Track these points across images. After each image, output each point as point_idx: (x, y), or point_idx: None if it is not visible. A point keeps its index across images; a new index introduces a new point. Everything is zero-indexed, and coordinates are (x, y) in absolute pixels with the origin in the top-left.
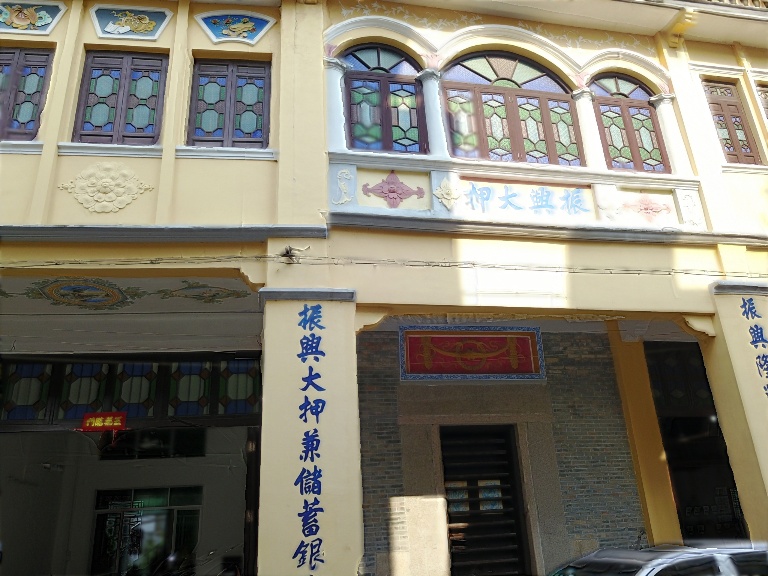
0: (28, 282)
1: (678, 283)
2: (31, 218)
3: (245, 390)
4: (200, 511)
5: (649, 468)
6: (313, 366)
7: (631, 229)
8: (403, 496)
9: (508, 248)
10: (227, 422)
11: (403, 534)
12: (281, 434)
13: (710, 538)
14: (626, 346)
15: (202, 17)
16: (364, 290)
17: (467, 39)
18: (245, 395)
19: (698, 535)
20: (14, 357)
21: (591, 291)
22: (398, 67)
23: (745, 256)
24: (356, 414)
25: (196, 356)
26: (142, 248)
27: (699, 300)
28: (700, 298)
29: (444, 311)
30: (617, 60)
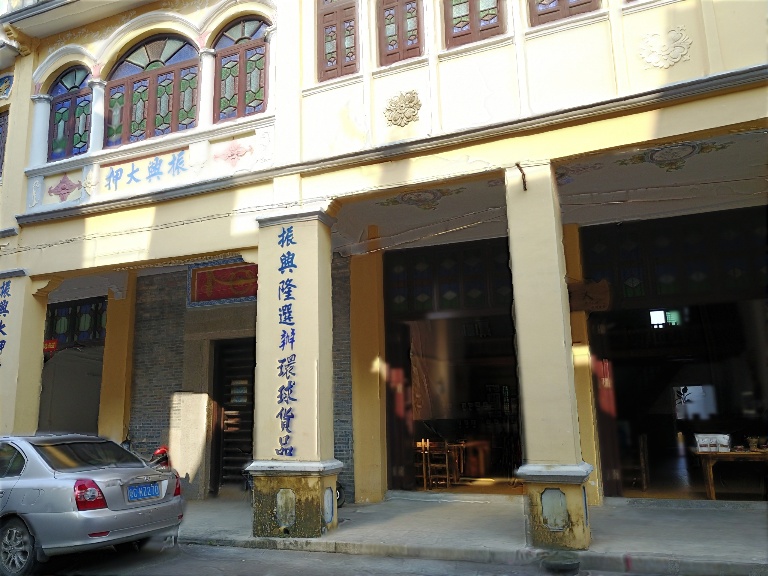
0: None
1: (235, 222)
2: None
3: None
4: None
5: (360, 370)
6: (3, 320)
7: (194, 183)
8: (181, 392)
9: (117, 218)
10: (98, 344)
11: (178, 418)
12: None
13: (480, 432)
14: (358, 259)
15: None
16: (35, 266)
17: (122, 38)
18: None
19: (471, 429)
20: None
21: (167, 242)
22: (85, 81)
23: (305, 182)
24: (19, 348)
25: (87, 301)
26: None
27: (249, 235)
28: (251, 233)
29: None
30: (237, 5)
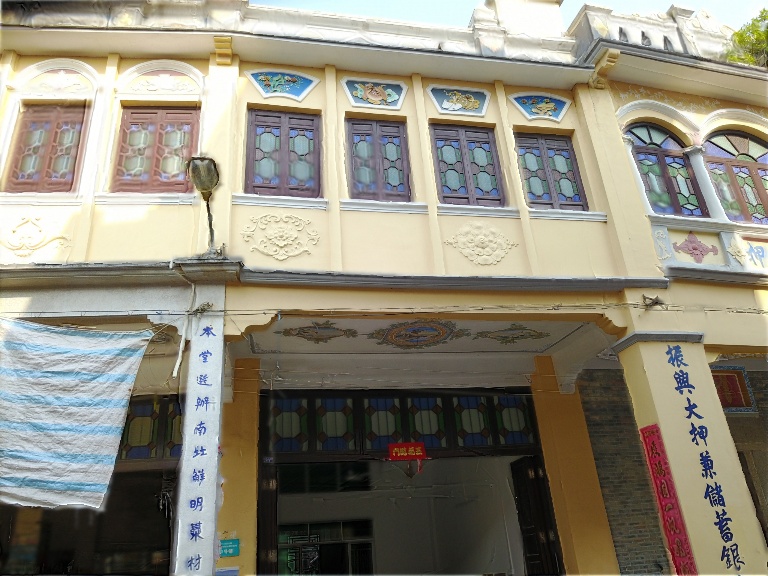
0: (387, 324)
1: None
2: (437, 269)
3: (518, 423)
4: (372, 544)
5: None
6: (689, 397)
7: None
8: None
9: None
10: (511, 452)
11: None
12: (683, 455)
13: None
14: None
15: (513, 97)
16: None
17: (715, 120)
18: (518, 427)
19: None
20: (318, 392)
21: None
22: (666, 143)
23: None
24: (731, 438)
25: (472, 392)
26: (528, 296)
27: None
28: None
29: (752, 351)
30: None
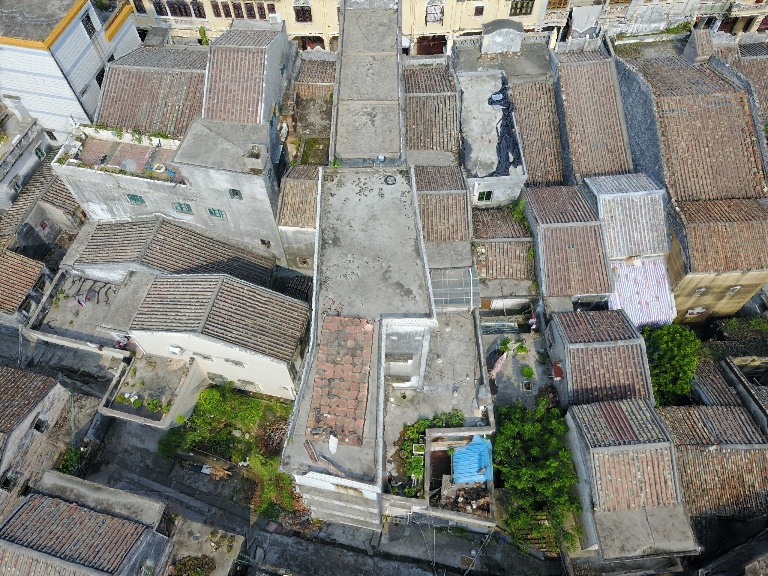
0: None
1: None
2: None
3: None
4: None
5: None
6: None
7: None
8: None
9: None
10: None
11: None
12: None
13: None
14: None
15: None
16: None
17: None
18: None
19: None
20: None
21: (194, 35)
22: None
23: None
24: None
25: None
26: None
27: None
28: None
29: None
30: None
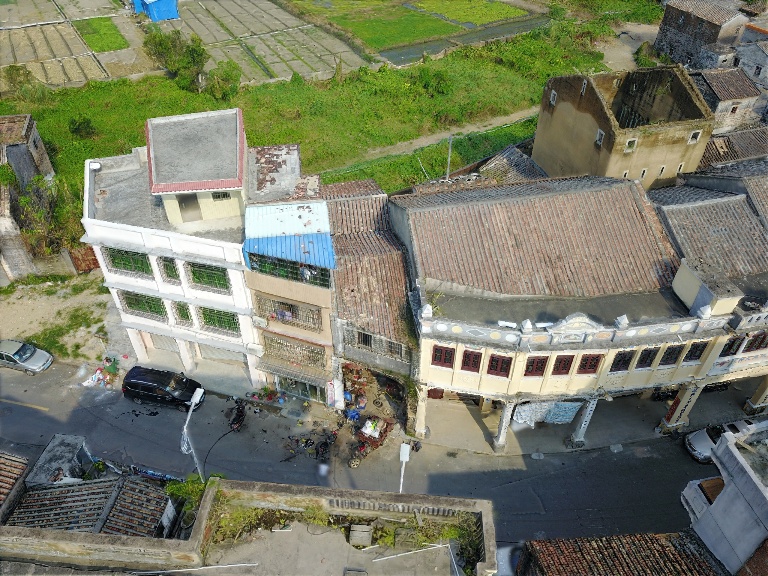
0: None
1: None
2: None
3: None
4: None
5: None
6: None
7: None
8: None
9: None
10: None
11: None
12: None
13: None
14: None
15: None
16: None
17: None
18: None
19: None
20: None
21: None
22: None
23: None
24: None
25: None
26: None
27: None
28: None
29: None
30: None
